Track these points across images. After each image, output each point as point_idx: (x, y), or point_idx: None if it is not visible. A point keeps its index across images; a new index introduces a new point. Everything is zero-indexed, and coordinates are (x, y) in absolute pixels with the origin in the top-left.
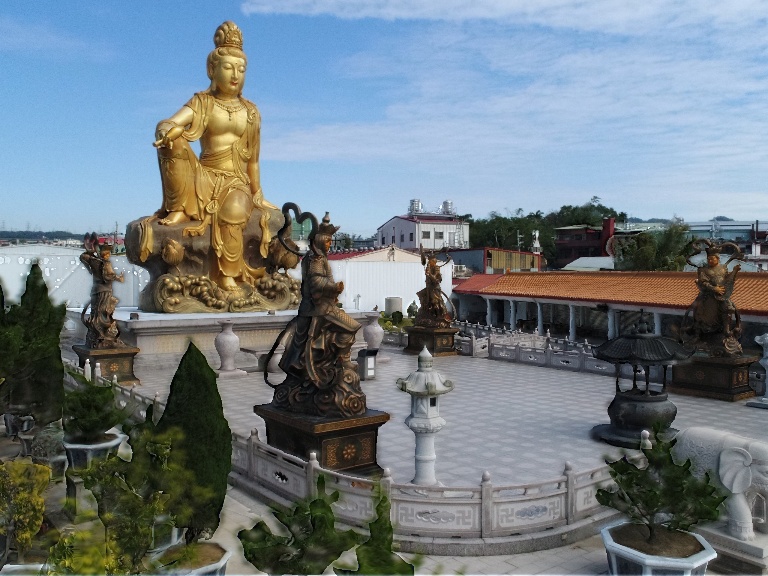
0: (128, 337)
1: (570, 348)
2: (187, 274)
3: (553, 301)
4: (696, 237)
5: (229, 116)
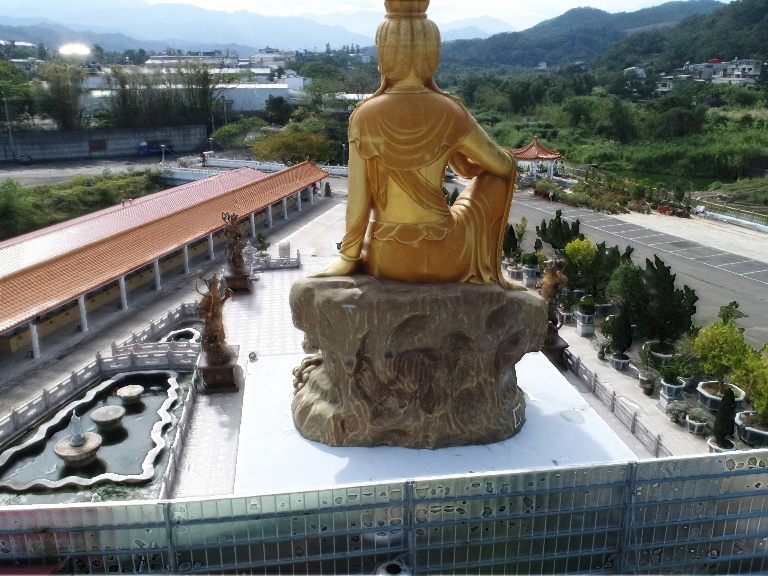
0: None
1: None
2: None
3: None
4: None
5: None
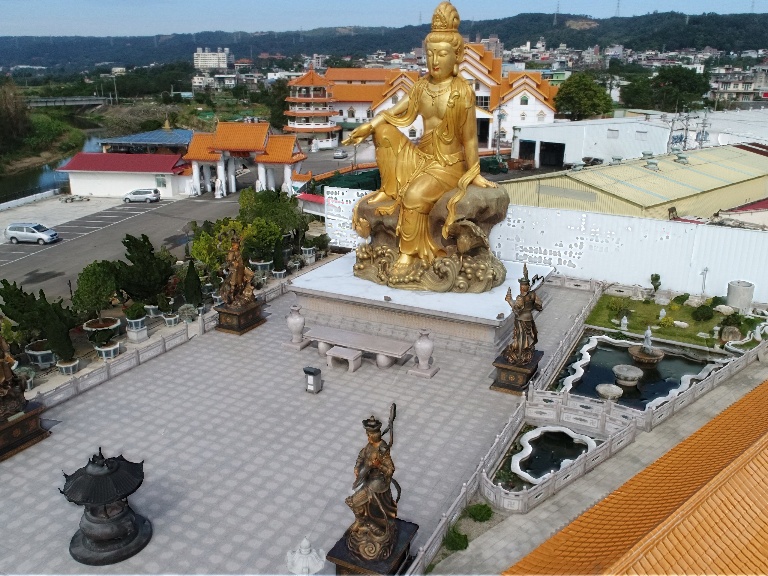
0: None
1: None
2: (387, 244)
3: None
4: None
5: (433, 101)
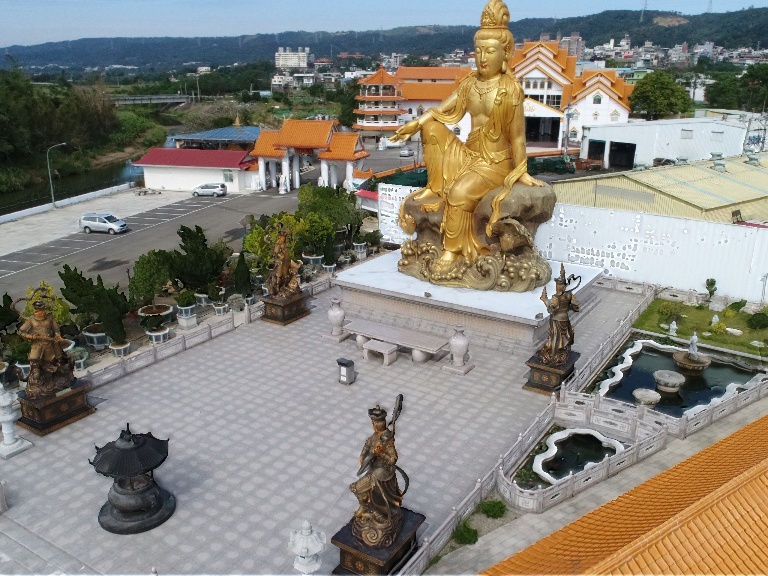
0: None
1: None
2: (432, 240)
3: None
4: None
5: (480, 98)
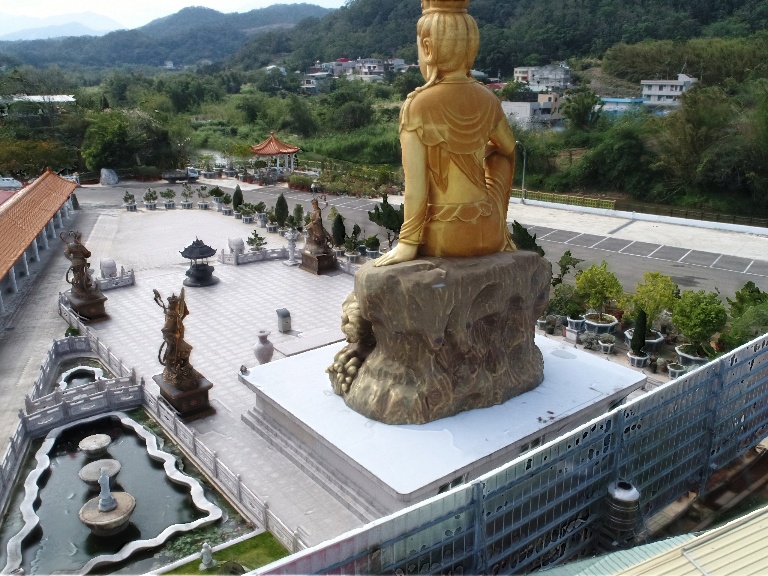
0: None
1: None
2: None
3: None
4: None
5: None
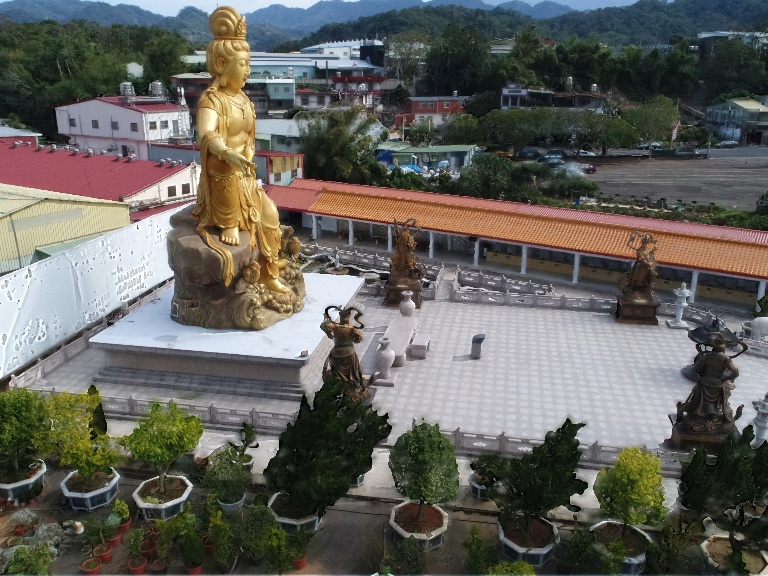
0: (282, 369)
1: (486, 280)
2: (244, 284)
3: (414, 228)
4: (372, 116)
5: (243, 114)
